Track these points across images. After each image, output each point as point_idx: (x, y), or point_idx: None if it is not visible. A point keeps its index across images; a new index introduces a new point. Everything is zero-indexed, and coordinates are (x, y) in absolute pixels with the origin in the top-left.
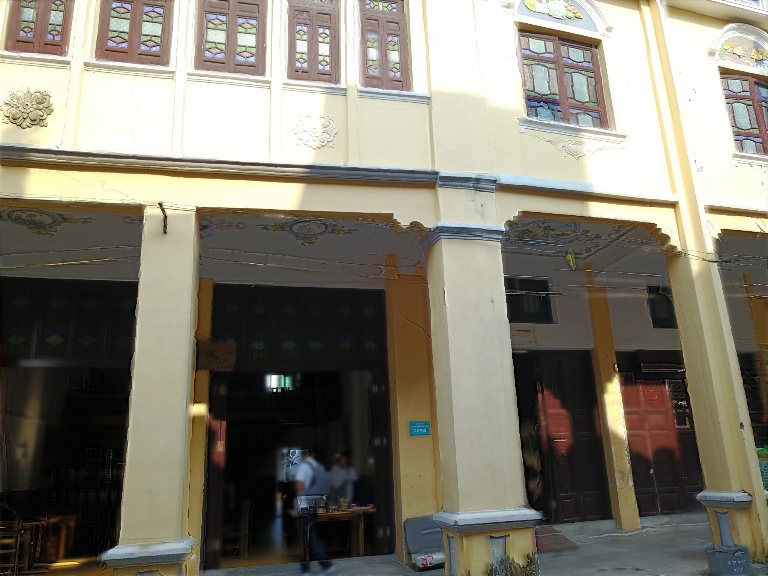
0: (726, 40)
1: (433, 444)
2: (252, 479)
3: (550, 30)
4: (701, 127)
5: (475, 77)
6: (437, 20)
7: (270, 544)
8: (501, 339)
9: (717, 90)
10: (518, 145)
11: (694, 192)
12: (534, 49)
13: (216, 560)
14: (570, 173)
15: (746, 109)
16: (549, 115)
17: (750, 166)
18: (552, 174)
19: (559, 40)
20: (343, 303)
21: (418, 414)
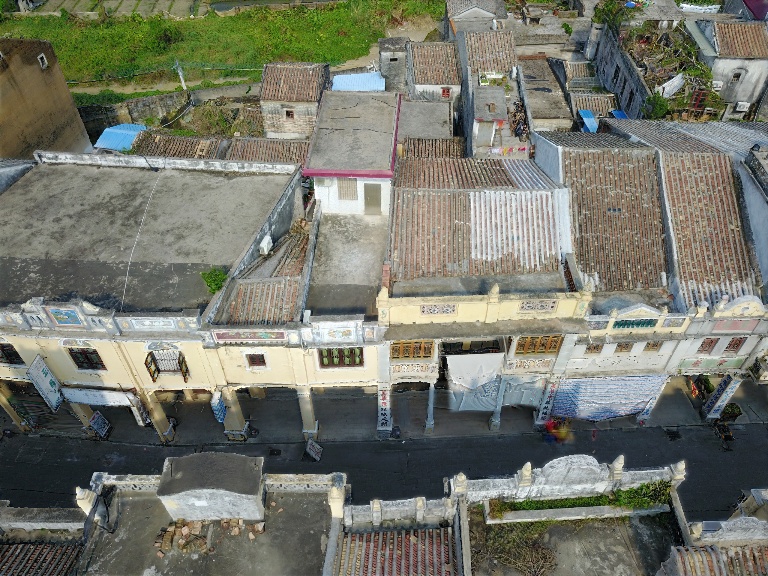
0: None
1: None
2: None
3: None
4: None
5: None
6: None
7: None
8: None
9: None
10: None
11: None
12: None
13: None
14: None
15: None
16: None
17: None
18: None
19: None
20: None
21: None
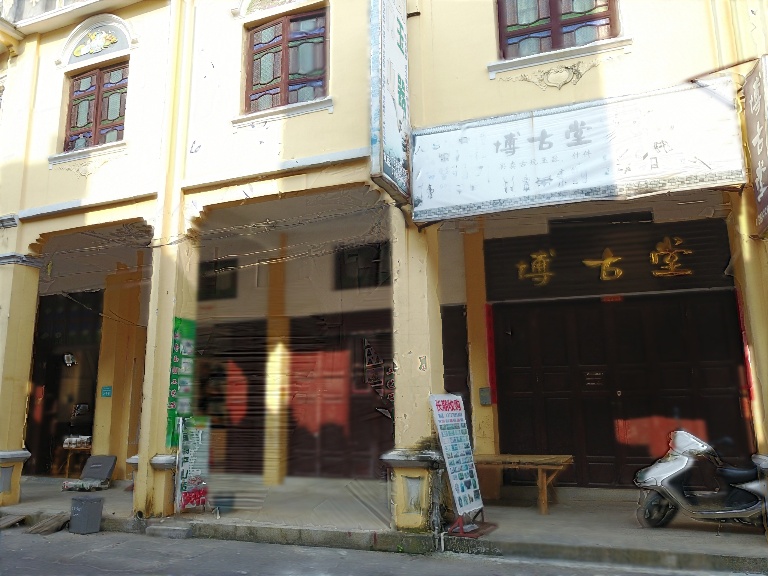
0: None
1: (118, 404)
2: (51, 423)
3: (93, 65)
4: (210, 102)
5: (21, 137)
6: (7, 101)
7: (59, 465)
8: (1, 335)
9: (237, 53)
10: (46, 181)
11: None
12: (83, 88)
13: (31, 471)
14: (78, 192)
15: (273, 58)
16: (84, 143)
17: (252, 127)
18: (64, 197)
19: (101, 70)
20: (101, 300)
21: (107, 381)
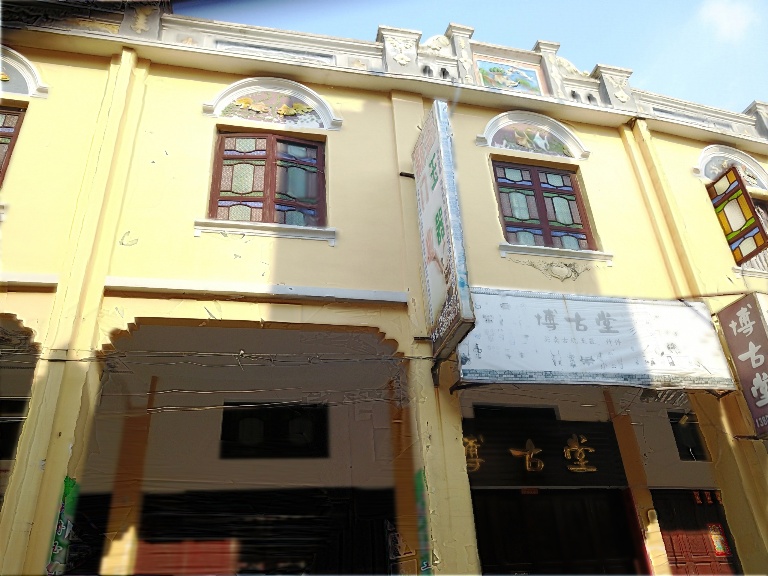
0: (242, 96)
1: None
2: None
3: None
4: (158, 192)
5: None
6: None
7: None
8: None
9: (204, 150)
10: None
11: (71, 269)
12: None
13: None
14: None
15: (252, 170)
16: None
17: (223, 236)
18: None
19: None
20: None
21: None
